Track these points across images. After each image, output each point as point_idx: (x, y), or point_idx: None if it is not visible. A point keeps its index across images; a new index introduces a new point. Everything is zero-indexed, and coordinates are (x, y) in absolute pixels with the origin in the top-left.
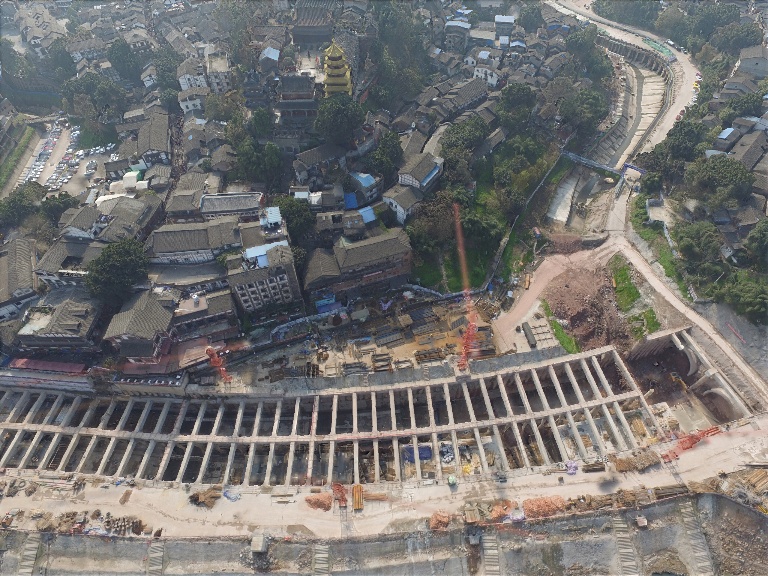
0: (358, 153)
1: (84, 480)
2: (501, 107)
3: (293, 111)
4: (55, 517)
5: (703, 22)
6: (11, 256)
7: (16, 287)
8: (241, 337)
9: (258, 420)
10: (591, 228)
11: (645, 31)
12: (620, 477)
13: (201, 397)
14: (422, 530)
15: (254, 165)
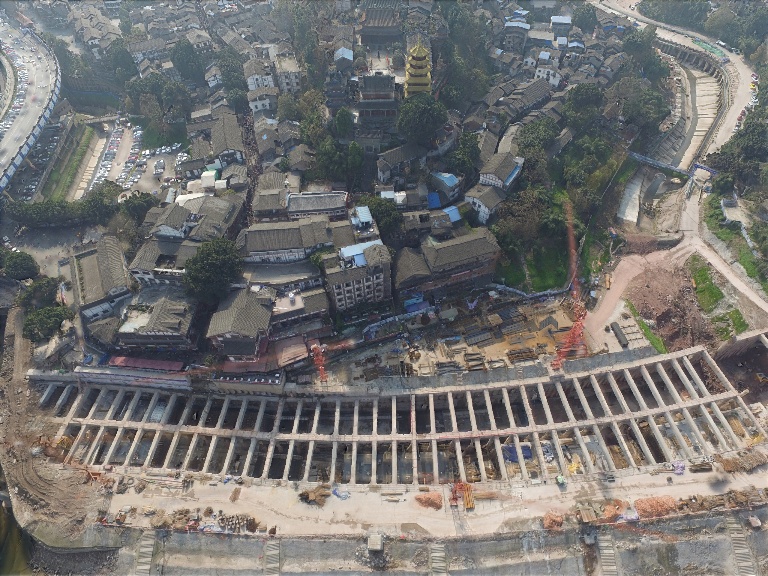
0: (438, 153)
1: (192, 478)
2: (569, 107)
3: (372, 111)
4: (168, 514)
5: (758, 23)
6: (102, 254)
7: (112, 285)
8: (334, 336)
9: (357, 419)
10: (663, 228)
11: (694, 32)
12: (729, 477)
13: (297, 395)
14: (537, 529)
15: (336, 165)
